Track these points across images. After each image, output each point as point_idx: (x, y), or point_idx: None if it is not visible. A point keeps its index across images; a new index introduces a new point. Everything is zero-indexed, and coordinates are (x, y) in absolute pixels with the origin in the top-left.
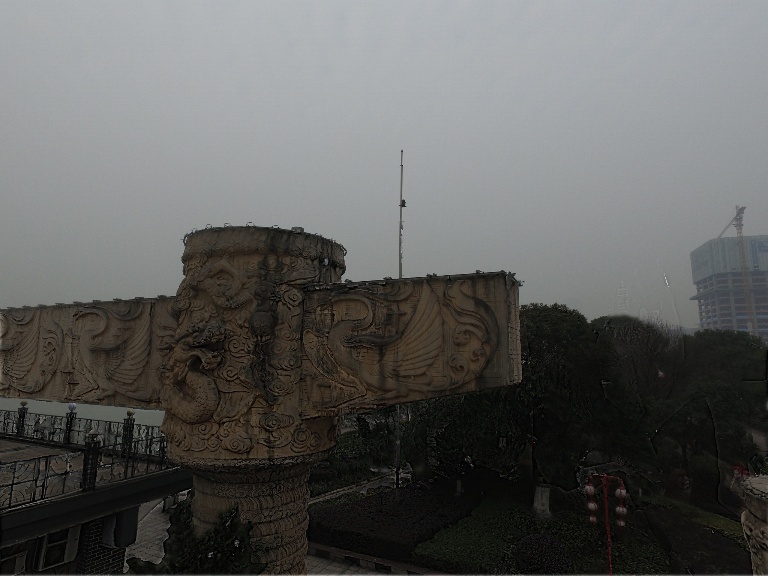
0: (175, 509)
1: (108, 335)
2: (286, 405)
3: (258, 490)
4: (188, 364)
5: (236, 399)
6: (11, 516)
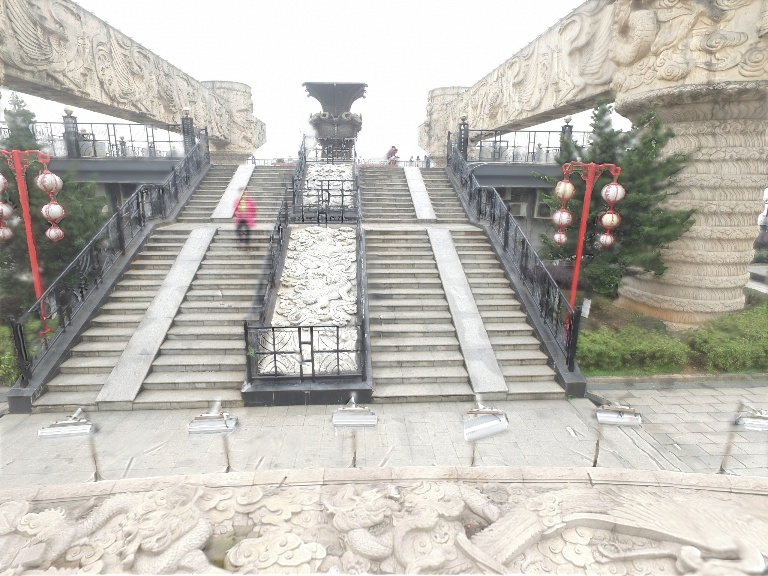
0: None
1: (582, 36)
2: (738, 21)
3: (697, 127)
4: (631, 3)
5: (676, 25)
6: (514, 167)
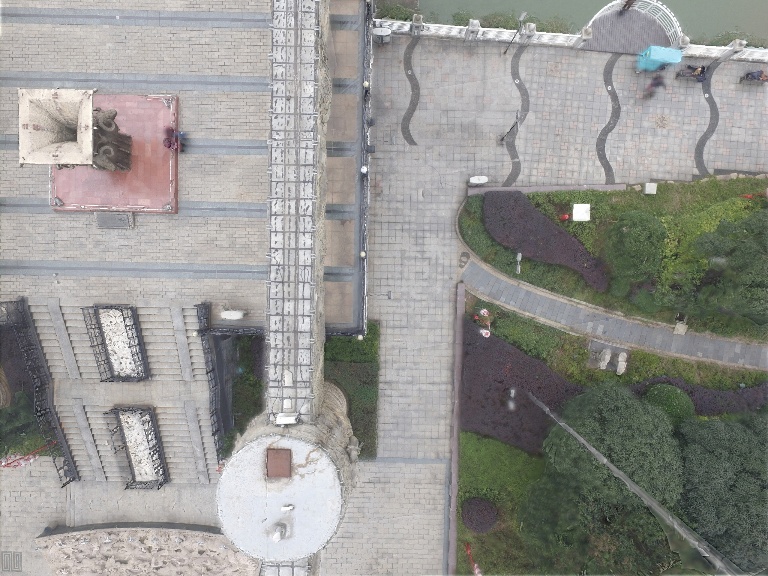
0: (468, 197)
1: None
2: None
3: None
4: None
5: None
6: None
